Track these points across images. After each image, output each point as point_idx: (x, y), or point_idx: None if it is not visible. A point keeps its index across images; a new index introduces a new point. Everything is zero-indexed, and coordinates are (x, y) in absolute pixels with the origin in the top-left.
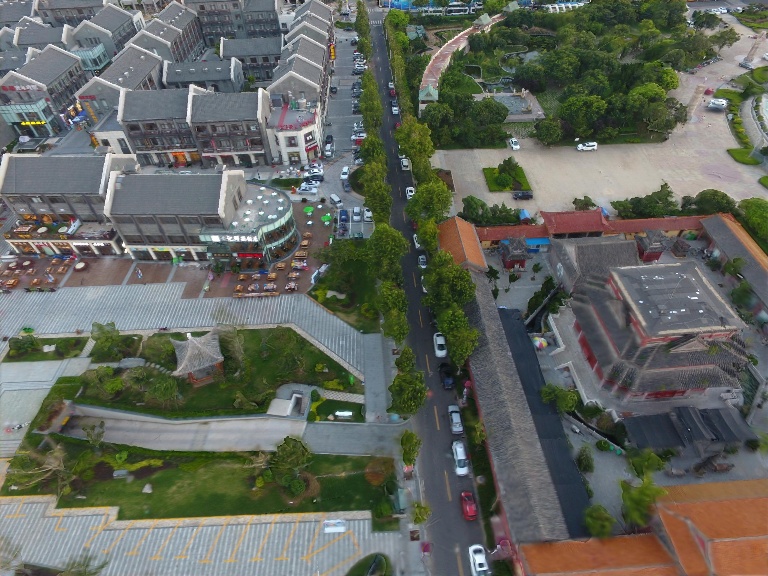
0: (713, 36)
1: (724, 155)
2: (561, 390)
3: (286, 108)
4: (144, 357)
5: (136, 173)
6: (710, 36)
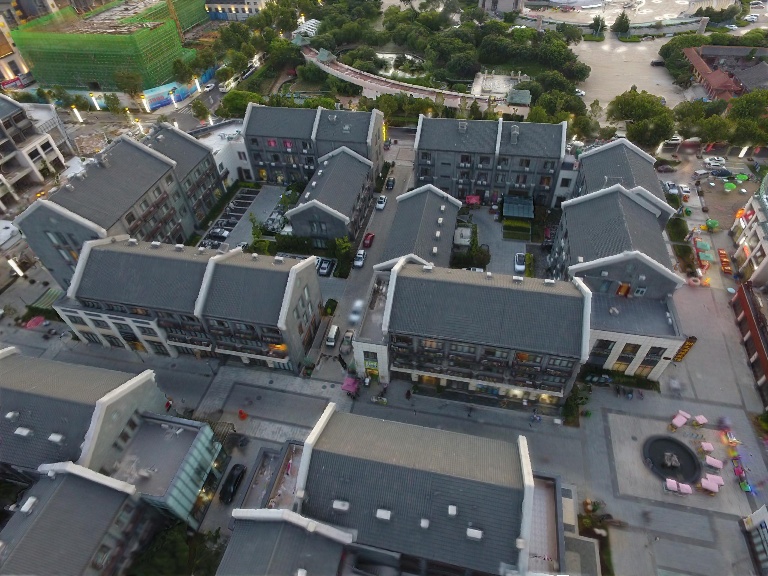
0: (423, 3)
1: (590, 43)
2: None
3: None
4: None
5: None
6: (419, 4)
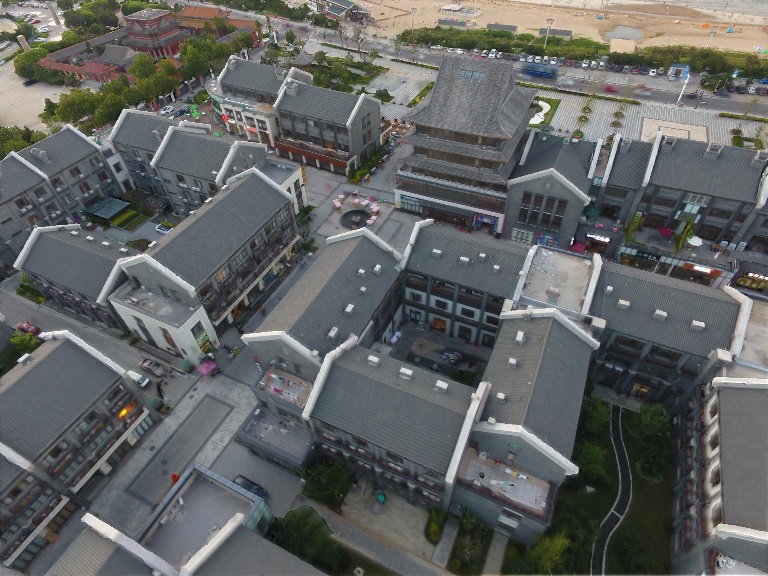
0: None
1: None
2: None
3: None
4: None
5: None
6: None
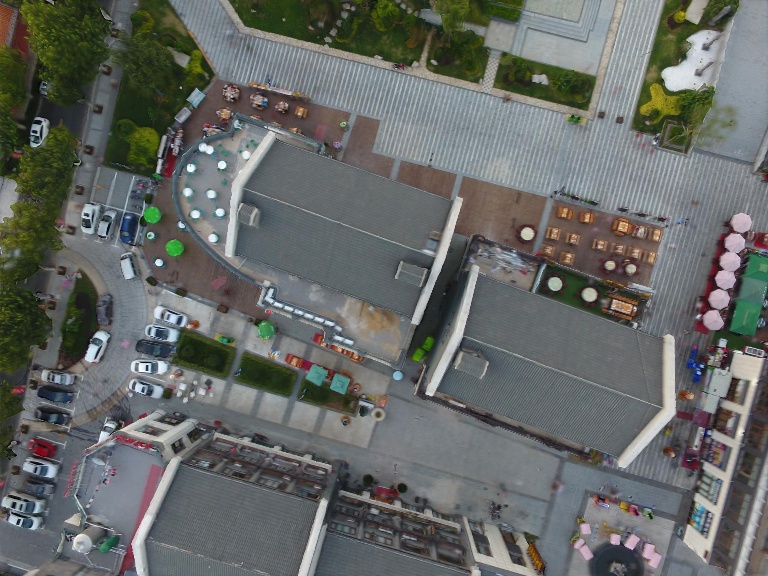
0: None
1: None
2: None
3: (130, 551)
4: None
5: None
6: None
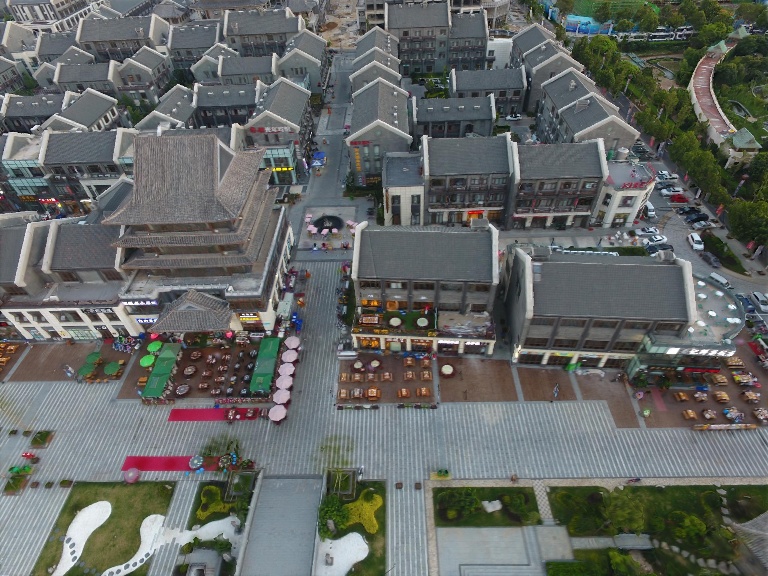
0: None
1: None
2: None
3: None
4: (649, 532)
5: (547, 258)
6: None
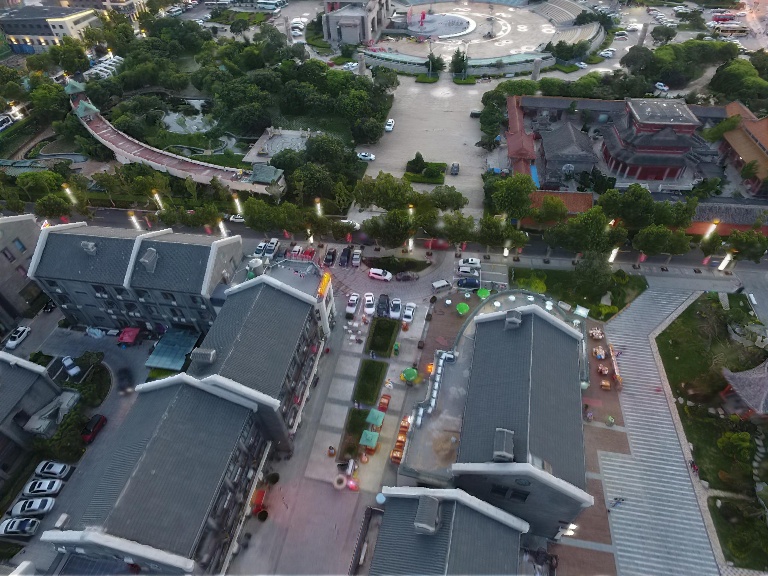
0: (257, 34)
1: (420, 85)
2: (696, 189)
3: None
4: None
5: None
6: (253, 35)
